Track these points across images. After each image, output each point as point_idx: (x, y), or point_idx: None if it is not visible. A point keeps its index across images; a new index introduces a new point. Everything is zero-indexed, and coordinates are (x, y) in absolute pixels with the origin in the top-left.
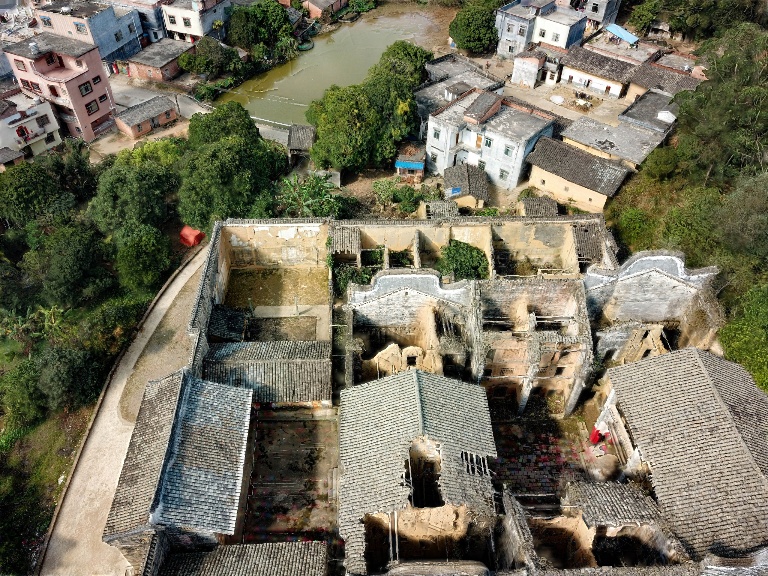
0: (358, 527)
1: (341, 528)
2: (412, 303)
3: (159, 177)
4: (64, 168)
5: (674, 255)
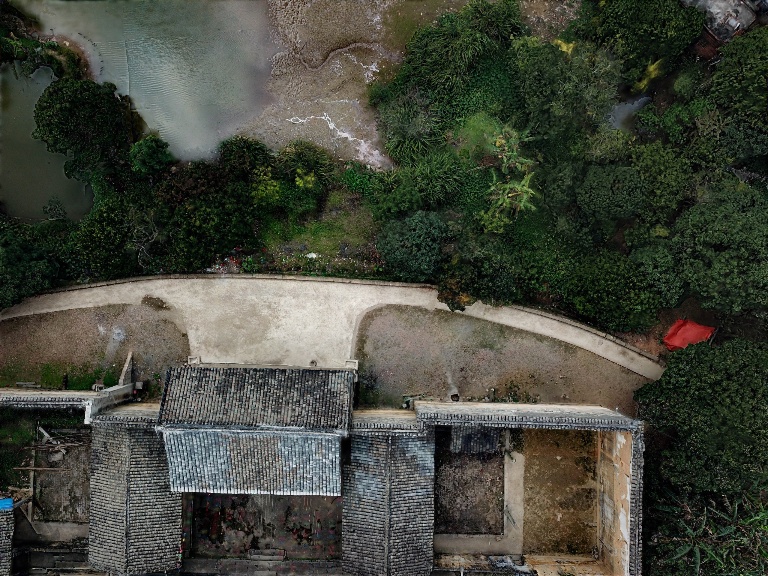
0: None
1: None
2: None
3: None
4: None
5: None
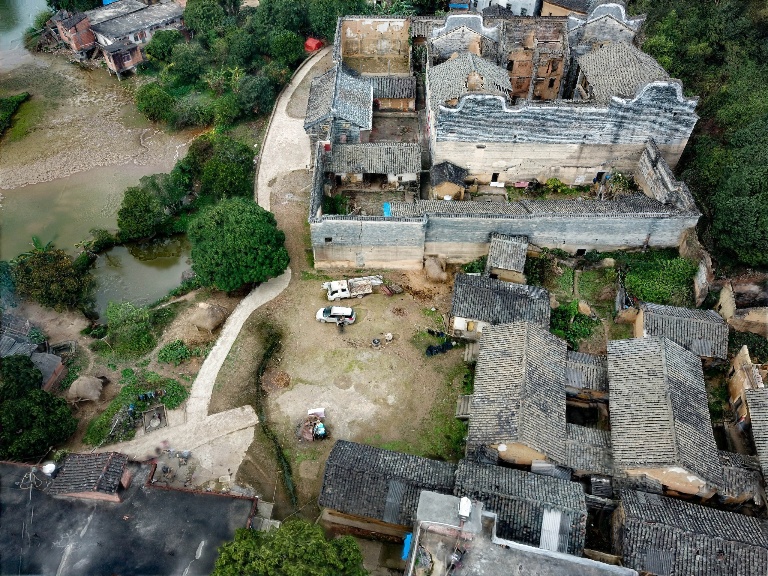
0: None
1: (432, 107)
2: (466, 39)
3: (295, 1)
4: (226, 3)
5: (619, 3)
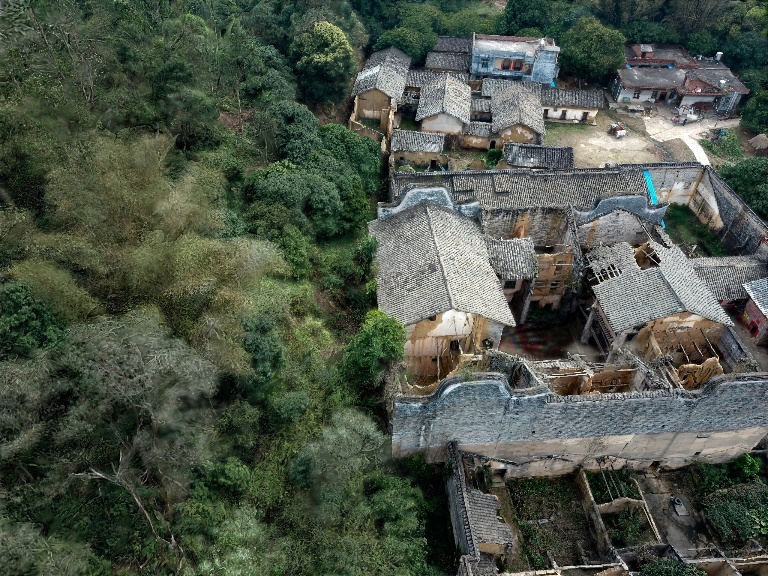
0: (670, 245)
1: None
2: None
3: None
4: None
5: None
